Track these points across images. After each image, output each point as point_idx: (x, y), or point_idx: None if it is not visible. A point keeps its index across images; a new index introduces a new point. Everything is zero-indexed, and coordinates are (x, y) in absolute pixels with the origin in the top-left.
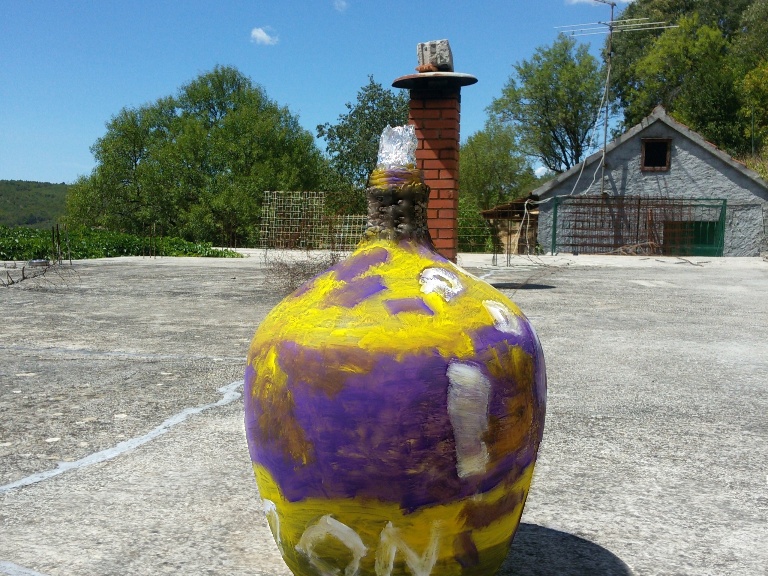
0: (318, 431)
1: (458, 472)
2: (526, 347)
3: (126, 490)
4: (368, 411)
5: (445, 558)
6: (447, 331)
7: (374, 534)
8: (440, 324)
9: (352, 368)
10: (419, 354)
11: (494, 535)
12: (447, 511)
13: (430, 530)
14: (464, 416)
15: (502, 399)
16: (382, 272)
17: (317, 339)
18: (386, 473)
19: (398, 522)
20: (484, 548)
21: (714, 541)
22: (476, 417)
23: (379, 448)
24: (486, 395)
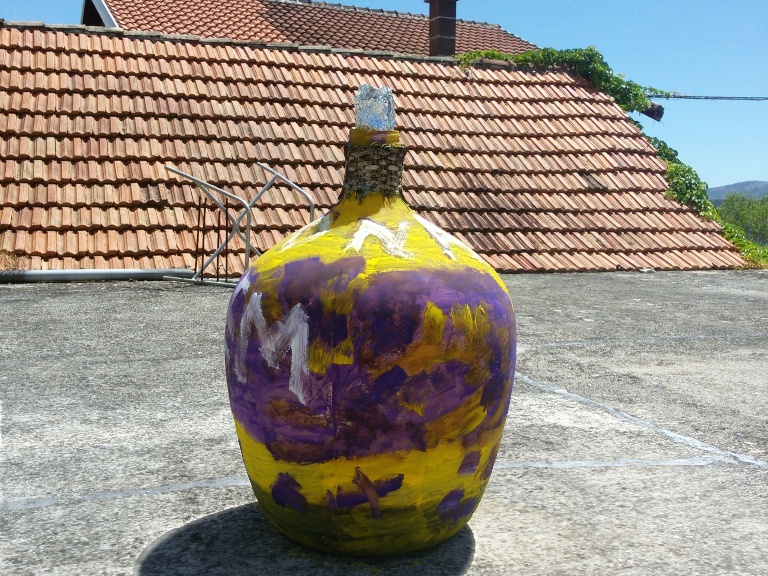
0: None
1: None
2: None
3: None
4: None
5: None
6: None
7: None
8: None
9: None
10: None
11: None
12: None
13: None
14: None
15: None
16: None
17: None
18: None
19: None
20: None
21: None
22: None
23: None
24: None
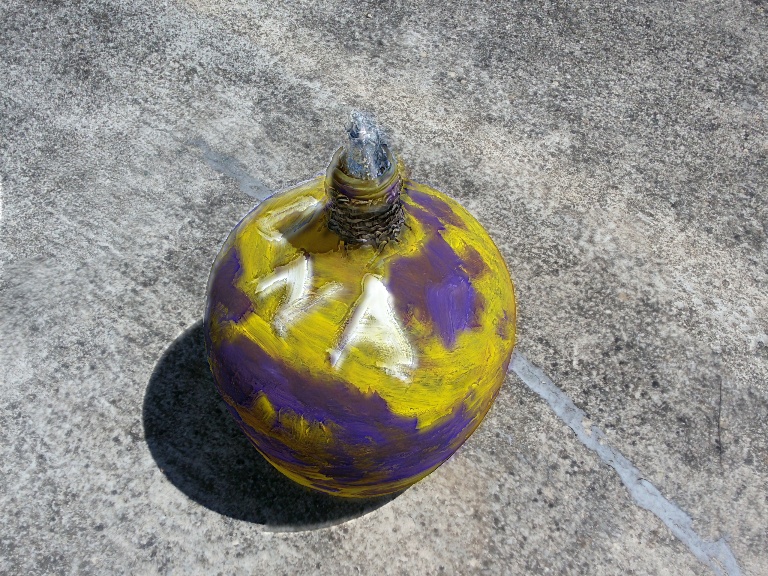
0: None
1: None
2: None
3: None
4: None
5: None
6: None
7: None
8: None
9: None
10: None
11: None
12: None
13: None
14: None
15: None
16: None
17: None
18: None
19: None
20: None
21: (33, 382)
22: None
23: None
24: None
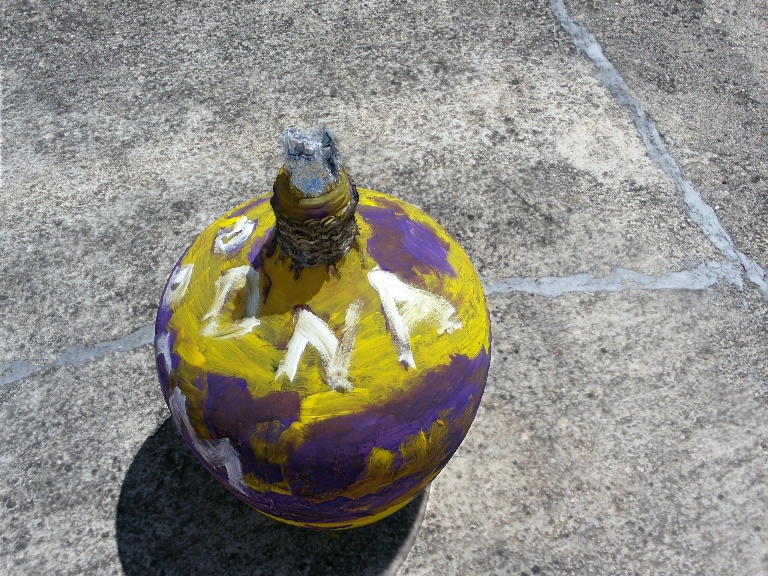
0: None
1: None
2: None
3: (738, 463)
4: None
5: None
6: None
7: None
8: None
9: None
10: None
11: None
12: None
13: None
14: None
15: None
16: None
17: None
18: None
19: None
20: None
21: None
22: None
23: None
24: None
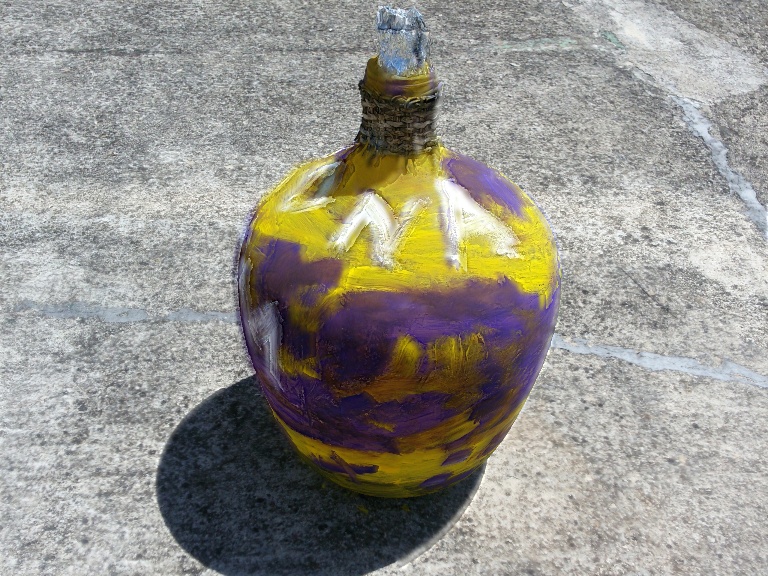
0: None
1: None
2: None
3: None
4: None
5: None
6: None
7: None
8: None
9: None
10: None
11: None
12: None
13: None
14: None
15: None
16: None
17: None
18: None
19: None
20: None
21: None
22: None
23: None
24: None
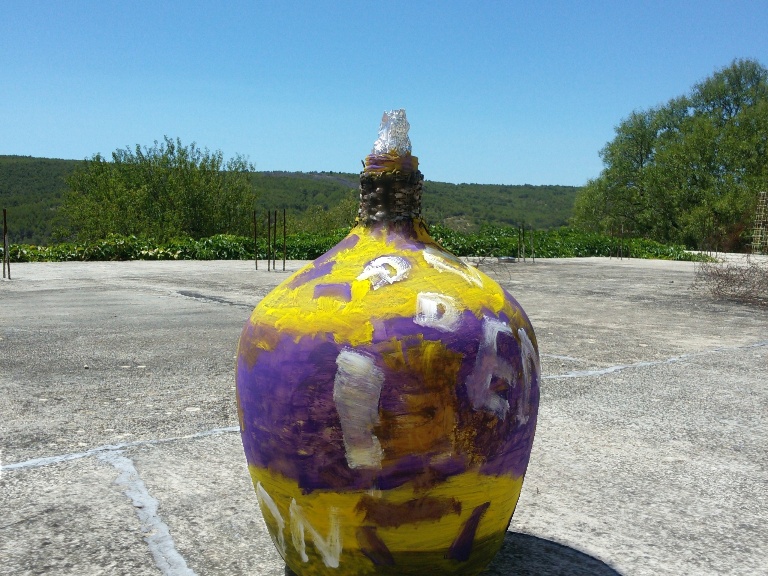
0: (245, 401)
1: (349, 462)
2: (457, 345)
3: None
4: (269, 388)
5: (351, 549)
6: (352, 319)
7: (285, 508)
8: (349, 311)
9: (264, 346)
10: (316, 338)
11: (412, 540)
12: (342, 500)
13: (329, 516)
14: (351, 406)
15: (400, 395)
16: (341, 258)
17: (257, 317)
18: (284, 450)
19: (300, 501)
20: (399, 550)
21: None
22: (365, 409)
23: (277, 424)
24: (378, 388)
